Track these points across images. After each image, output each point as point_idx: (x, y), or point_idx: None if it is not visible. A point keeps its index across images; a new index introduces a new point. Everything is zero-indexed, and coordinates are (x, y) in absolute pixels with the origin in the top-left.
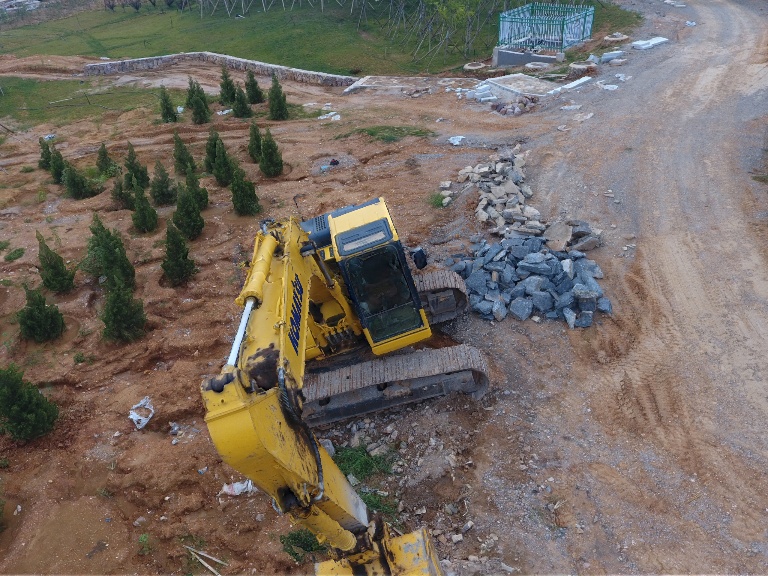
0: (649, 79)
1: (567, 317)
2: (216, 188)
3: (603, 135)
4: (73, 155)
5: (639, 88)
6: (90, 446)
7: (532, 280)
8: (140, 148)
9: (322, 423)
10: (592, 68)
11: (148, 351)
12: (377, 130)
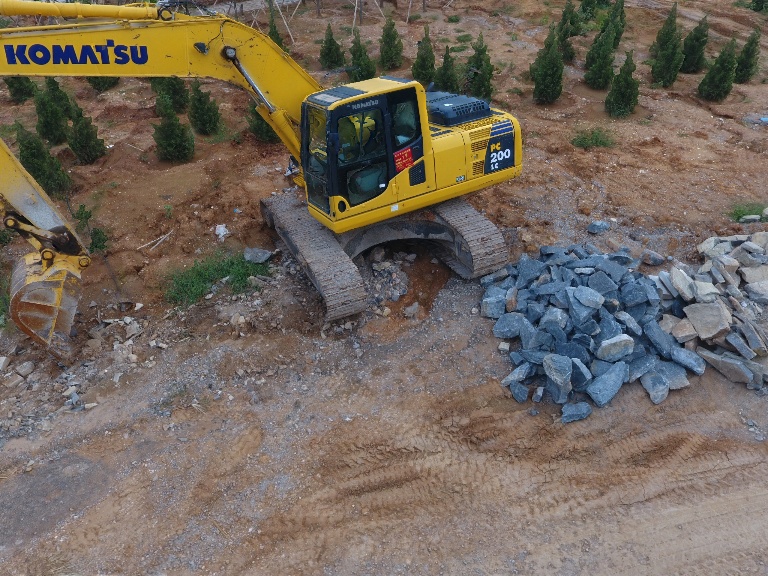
0: None
1: (514, 370)
2: (643, 80)
3: None
4: (632, 3)
5: None
6: (264, 163)
7: (555, 313)
8: (683, 20)
9: None
10: None
11: None
12: None
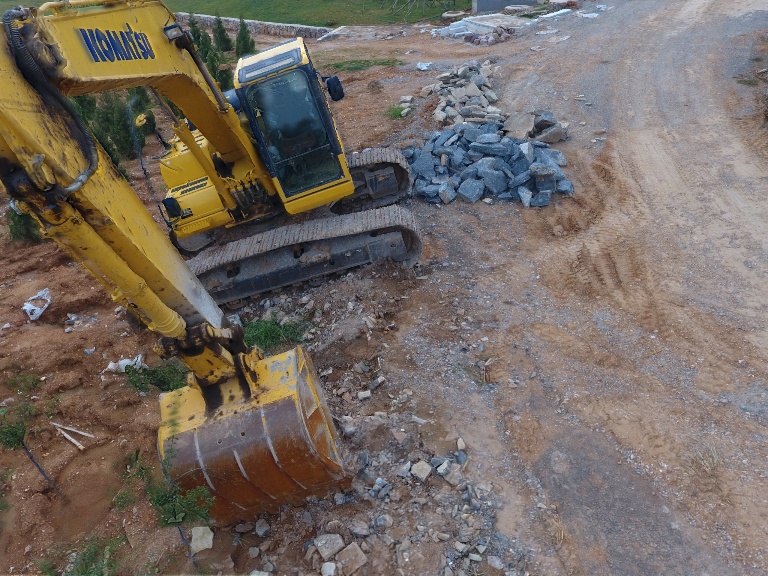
0: (631, 8)
1: (522, 196)
2: (167, 116)
3: (579, 52)
4: None
5: (620, 15)
6: None
7: (485, 161)
8: None
9: (231, 299)
10: (572, 2)
11: (58, 249)
12: (343, 64)
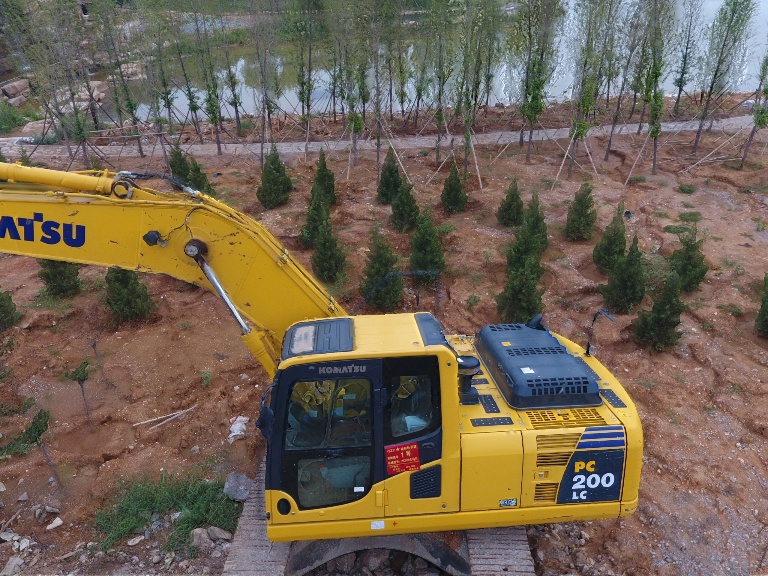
0: None
1: None
2: None
3: None
4: None
5: None
6: None
7: None
8: None
9: None
10: None
11: None
12: None
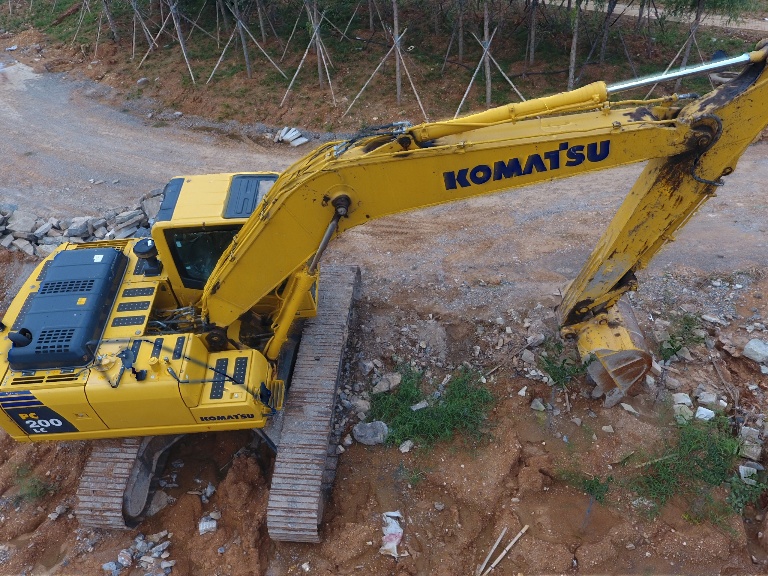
0: None
1: None
2: None
3: None
4: None
5: None
6: None
7: None
8: None
9: None
10: None
11: None
12: None
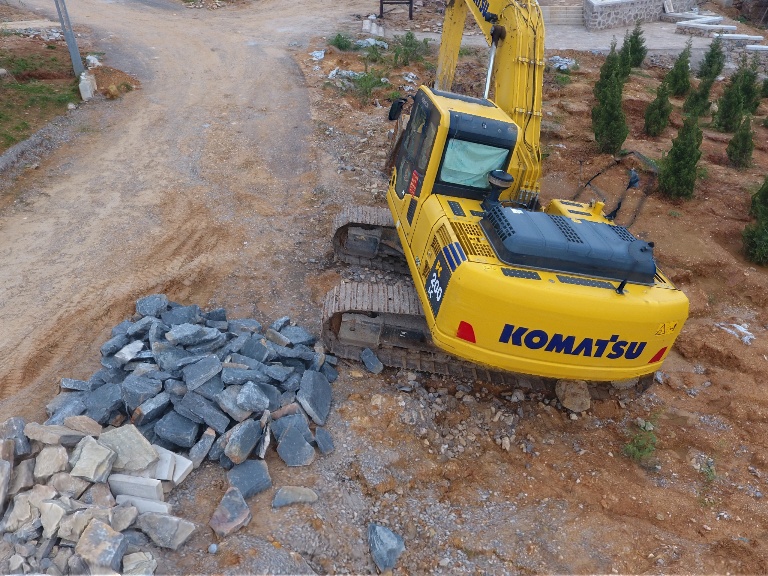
0: None
1: None
2: None
3: None
4: None
5: None
6: (761, 316)
7: None
8: None
9: None
10: None
11: None
12: None
